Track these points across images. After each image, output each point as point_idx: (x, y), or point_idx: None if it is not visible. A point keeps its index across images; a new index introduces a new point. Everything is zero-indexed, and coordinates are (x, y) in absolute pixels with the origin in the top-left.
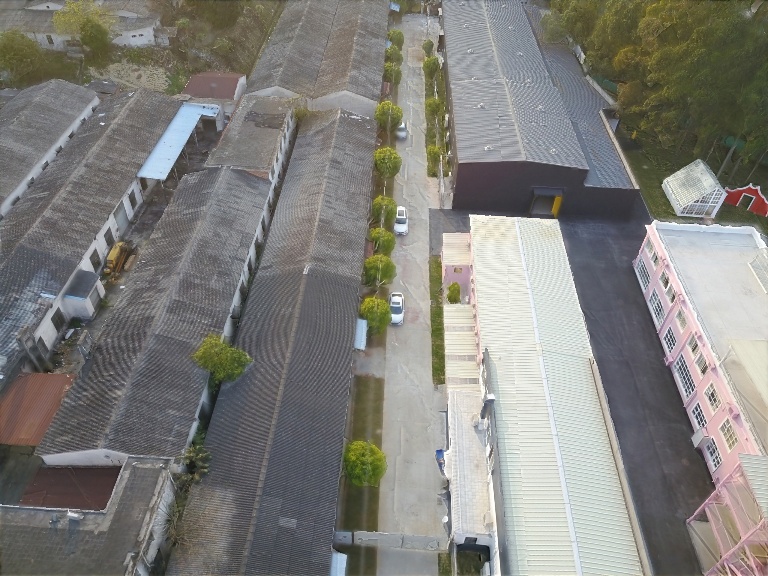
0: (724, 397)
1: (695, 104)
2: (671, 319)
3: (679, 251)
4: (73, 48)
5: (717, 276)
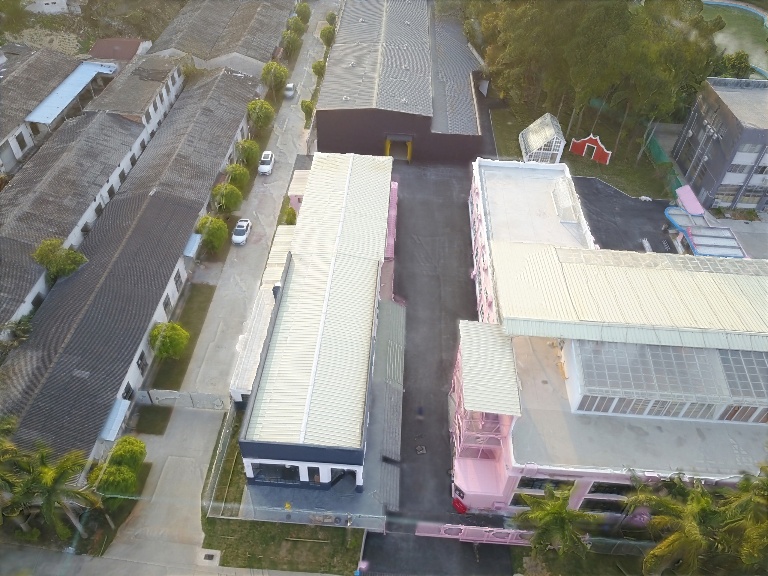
0: (488, 291)
1: (534, 60)
2: (477, 239)
3: (494, 182)
4: None
5: (520, 202)
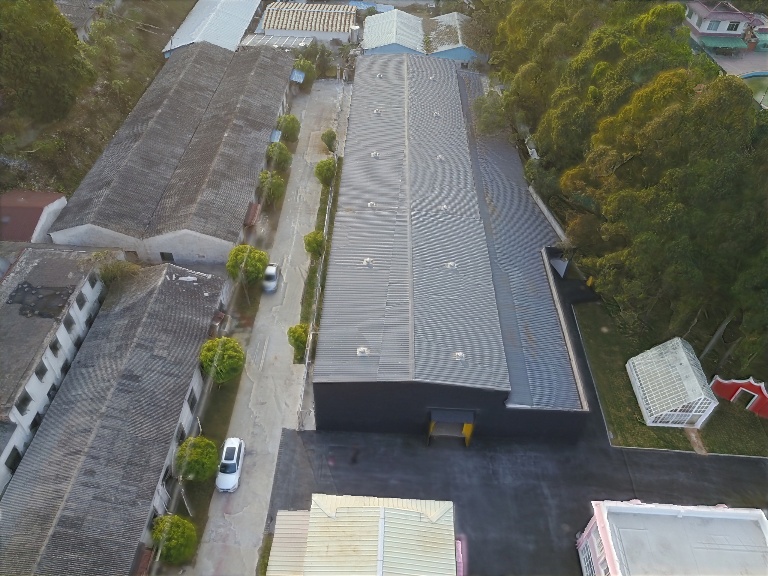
0: None
1: None
2: None
3: (643, 568)
4: None
5: None
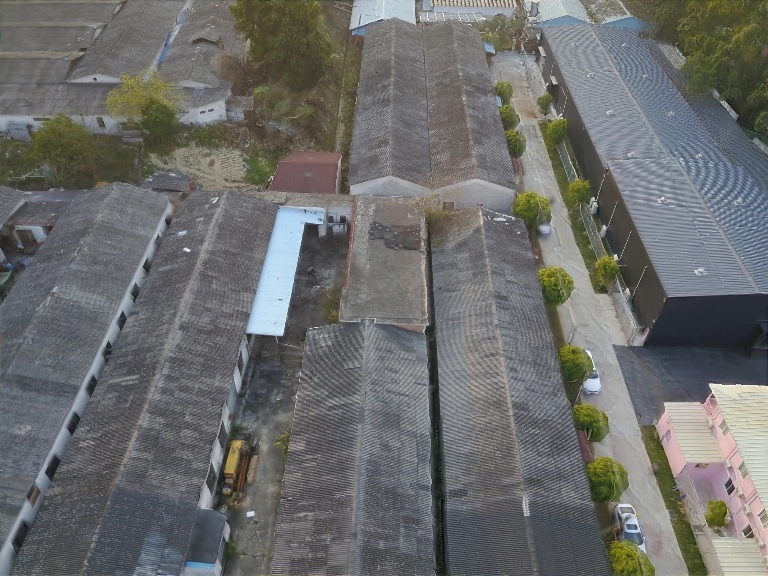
0: None
1: None
2: None
3: None
4: (130, 132)
5: None
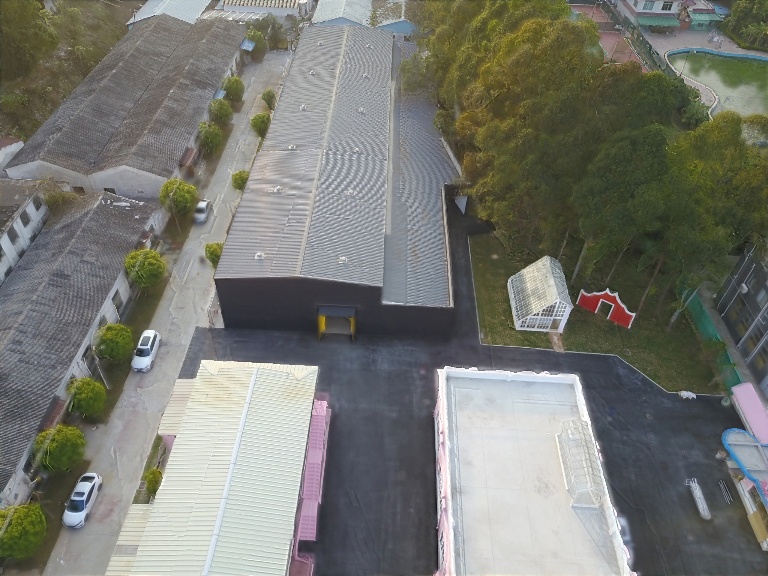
0: None
1: (527, 196)
2: (442, 521)
3: (468, 415)
4: None
5: (508, 459)
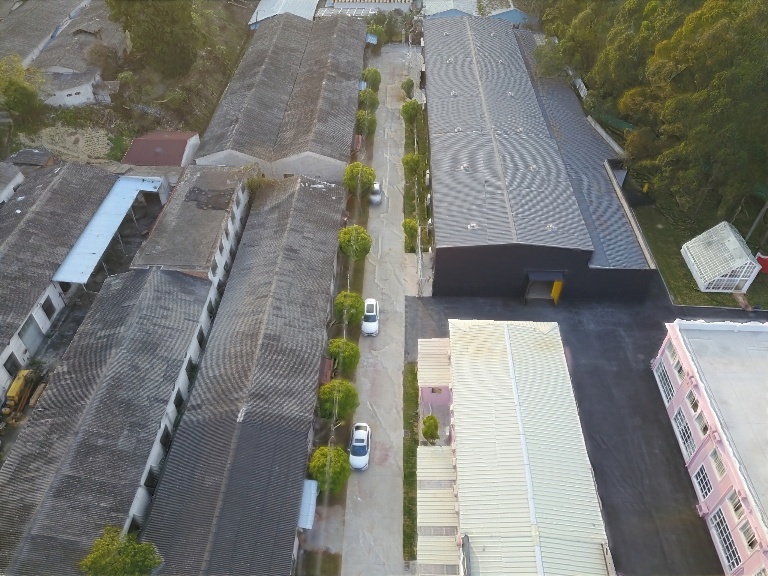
0: None
1: (719, 163)
2: (704, 456)
3: (709, 362)
4: None
5: (760, 398)
